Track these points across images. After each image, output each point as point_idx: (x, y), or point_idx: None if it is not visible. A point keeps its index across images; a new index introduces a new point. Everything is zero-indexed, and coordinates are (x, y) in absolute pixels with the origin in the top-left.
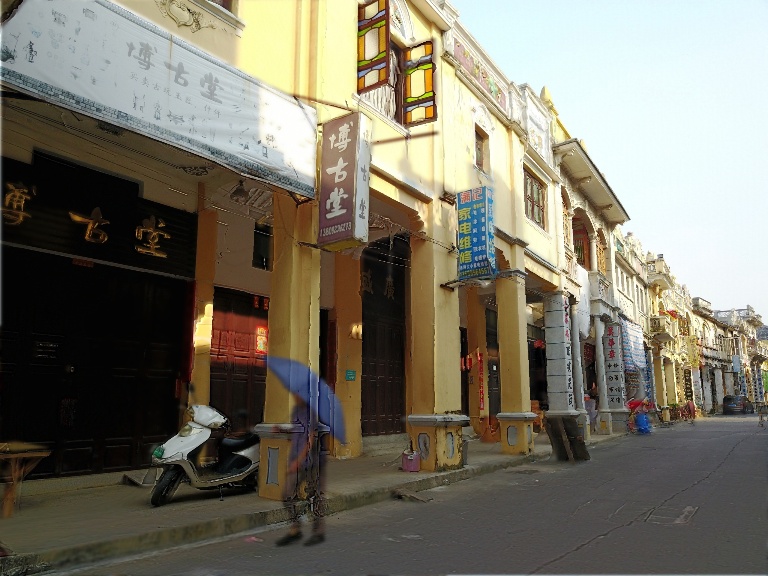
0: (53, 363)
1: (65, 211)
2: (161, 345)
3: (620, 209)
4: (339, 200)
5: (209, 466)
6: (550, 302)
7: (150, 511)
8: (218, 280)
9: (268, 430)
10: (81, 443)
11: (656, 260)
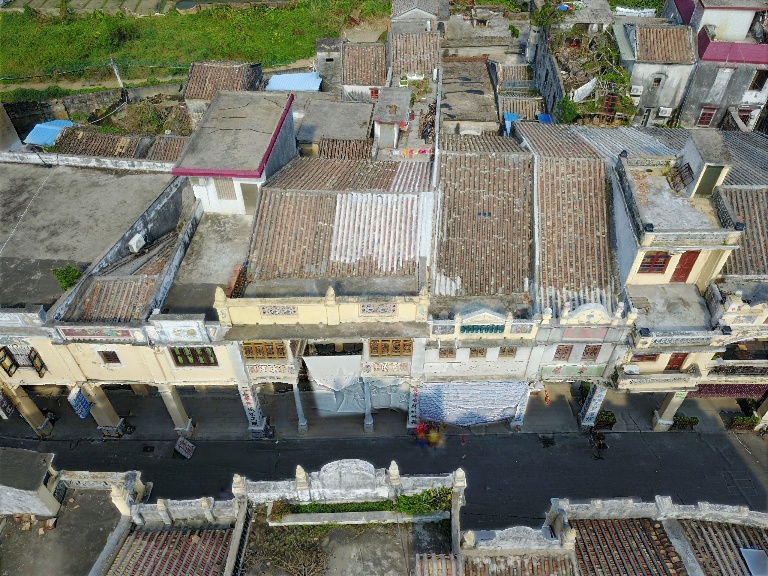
0: None
1: None
2: None
3: None
4: None
5: None
6: None
7: None
8: None
9: None
10: None
11: (638, 331)
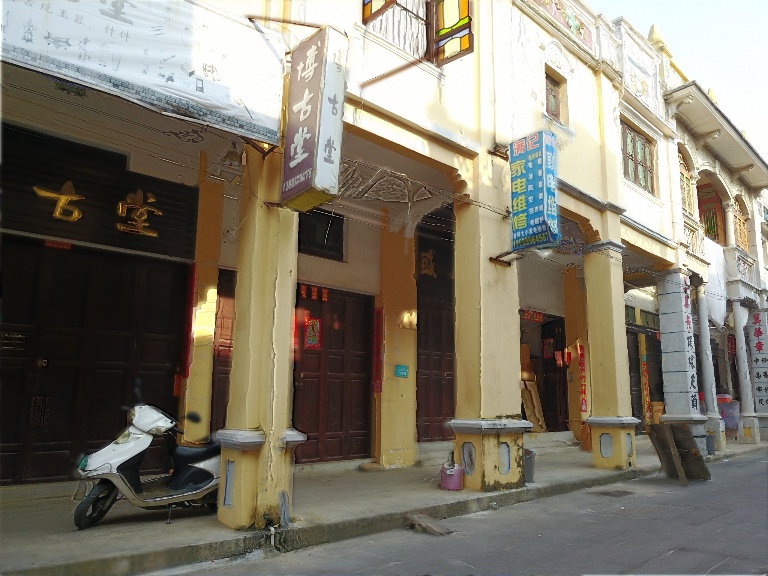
0: (21, 356)
1: (28, 186)
2: (158, 336)
3: (765, 170)
4: (302, 142)
5: (156, 480)
6: (665, 283)
7: (67, 535)
8: (226, 262)
9: (229, 437)
10: (56, 445)
11: None
